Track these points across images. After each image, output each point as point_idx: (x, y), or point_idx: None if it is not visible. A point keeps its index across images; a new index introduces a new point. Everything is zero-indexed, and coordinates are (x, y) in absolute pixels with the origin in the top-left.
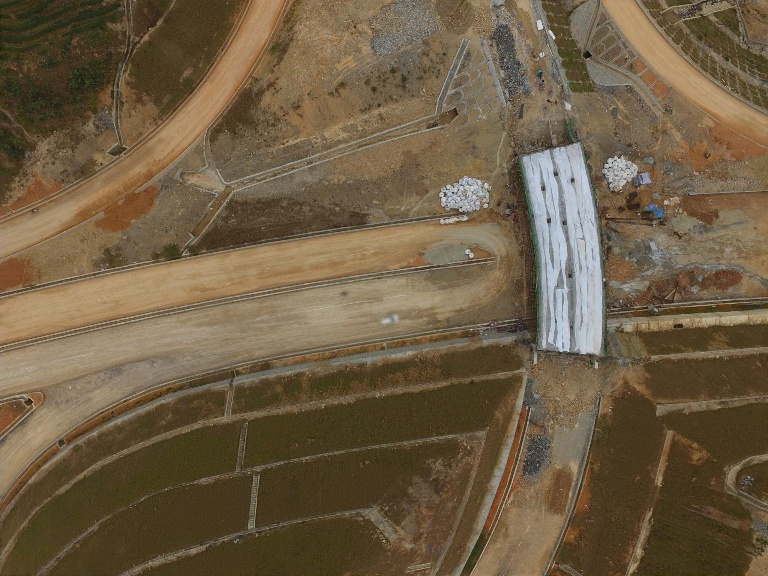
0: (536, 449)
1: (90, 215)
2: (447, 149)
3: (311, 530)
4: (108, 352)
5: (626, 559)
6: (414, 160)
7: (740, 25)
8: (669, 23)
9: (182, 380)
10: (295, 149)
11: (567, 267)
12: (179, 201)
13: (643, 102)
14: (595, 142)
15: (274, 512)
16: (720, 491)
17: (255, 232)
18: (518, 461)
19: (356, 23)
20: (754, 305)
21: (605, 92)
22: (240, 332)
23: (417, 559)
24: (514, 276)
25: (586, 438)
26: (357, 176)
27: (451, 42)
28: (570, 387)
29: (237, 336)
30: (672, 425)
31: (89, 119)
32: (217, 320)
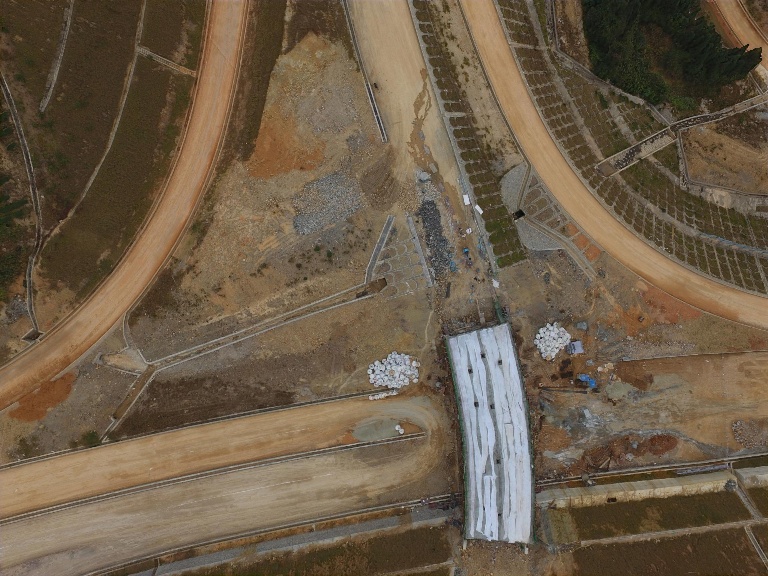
0: None
1: (5, 405)
2: (376, 320)
3: None
4: (26, 544)
5: None
6: (343, 332)
7: (680, 163)
8: (604, 177)
9: (104, 571)
10: (219, 326)
11: (495, 453)
12: (98, 386)
13: (576, 266)
14: (525, 316)
15: None
16: None
17: (177, 416)
18: None
19: (278, 201)
20: None
21: (537, 257)
22: (164, 518)
23: None
24: (446, 450)
25: None
26: (284, 351)
27: (376, 219)
28: None
29: (161, 522)
30: None
31: (1, 308)
32: (140, 507)
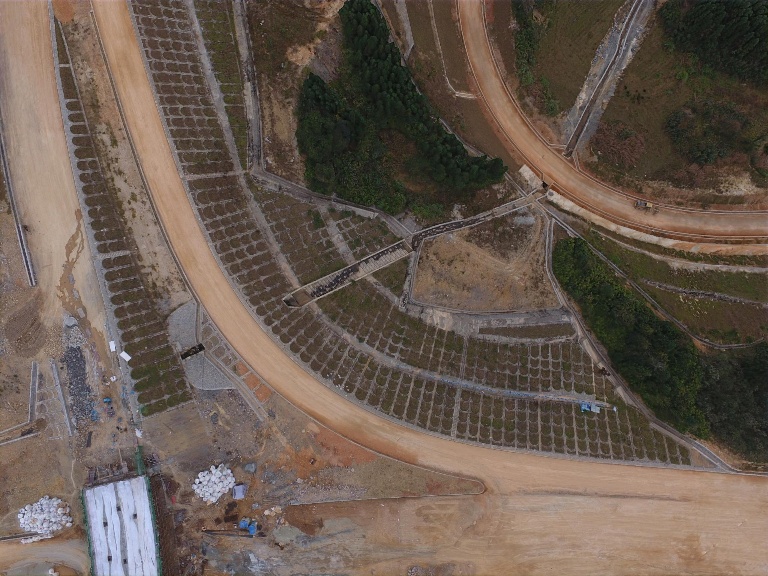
0: None
1: None
2: (38, 460)
3: None
4: None
5: None
6: (3, 472)
7: (407, 280)
8: (293, 308)
9: None
10: None
11: None
12: None
13: (246, 406)
14: (175, 464)
15: None
16: None
17: None
18: None
19: None
20: None
21: (205, 397)
22: None
23: None
24: None
25: None
26: None
27: (19, 366)
28: None
29: None
30: None
31: None
32: None
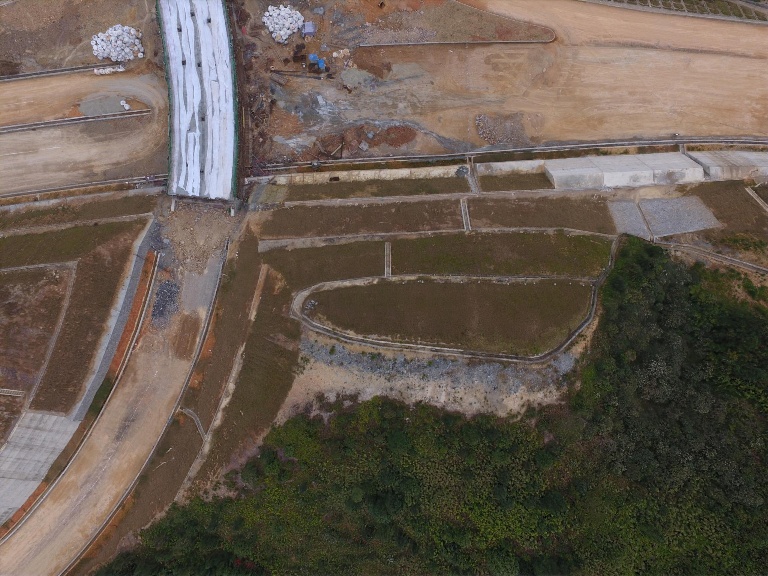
0: (161, 293)
1: None
2: None
3: None
4: None
5: (219, 394)
6: (74, 11)
7: None
8: None
9: None
10: None
11: (200, 110)
12: None
13: None
14: None
15: None
16: (286, 316)
17: None
18: (146, 306)
19: None
20: (426, 162)
21: None
22: None
23: None
24: None
25: (214, 284)
26: (16, 27)
27: None
28: (199, 232)
29: None
30: (269, 259)
31: None
32: None
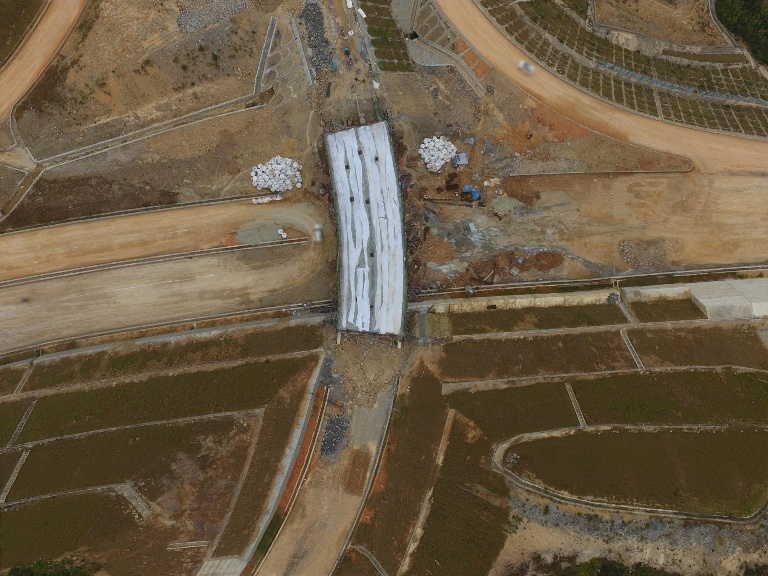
0: (333, 429)
1: None
2: (264, 129)
3: (60, 505)
4: None
5: (406, 539)
6: (230, 139)
7: (589, 9)
8: (500, 4)
9: None
10: (107, 127)
11: (369, 246)
12: None
13: (465, 82)
14: (407, 121)
15: (27, 487)
16: (487, 469)
17: (62, 210)
18: (315, 441)
19: (163, 0)
20: (575, 287)
21: (426, 72)
22: (47, 311)
23: (181, 536)
24: (329, 256)
25: (385, 418)
26: (171, 155)
27: (259, 20)
28: (369, 367)
29: (44, 315)
30: (455, 404)
31: None
32: (24, 299)
